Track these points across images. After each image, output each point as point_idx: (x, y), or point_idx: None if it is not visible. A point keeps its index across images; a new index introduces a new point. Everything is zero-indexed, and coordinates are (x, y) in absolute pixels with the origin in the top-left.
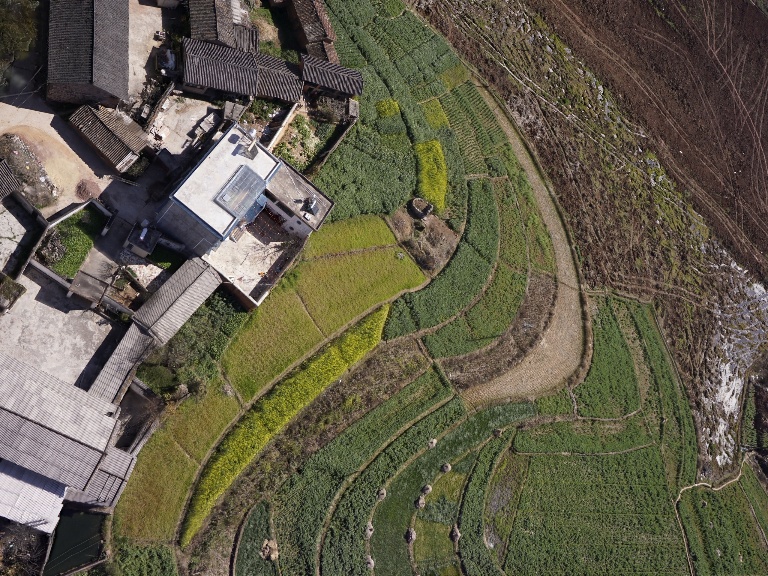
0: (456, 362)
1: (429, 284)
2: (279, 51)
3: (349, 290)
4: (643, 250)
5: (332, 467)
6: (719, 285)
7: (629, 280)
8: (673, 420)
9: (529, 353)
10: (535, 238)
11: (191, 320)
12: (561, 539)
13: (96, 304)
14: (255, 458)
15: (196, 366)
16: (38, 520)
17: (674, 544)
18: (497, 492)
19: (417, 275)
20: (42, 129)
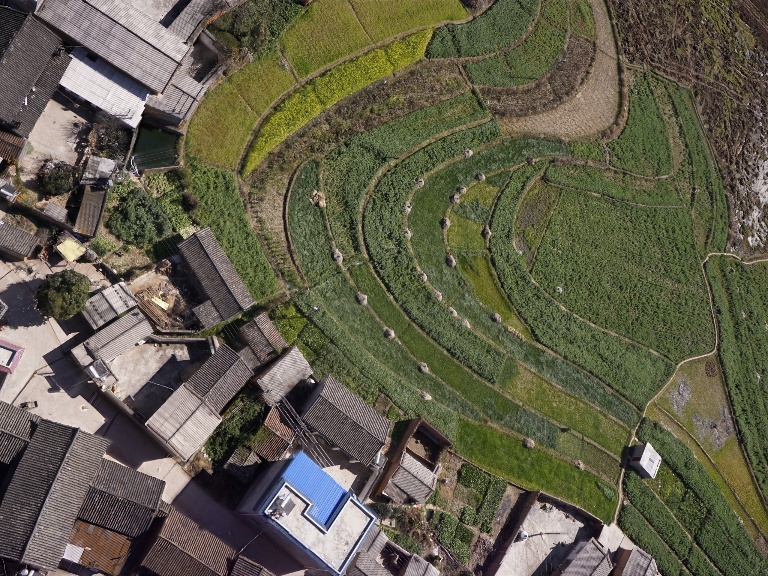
0: (494, 92)
1: (471, 20)
2: None
3: (396, 9)
4: (685, 42)
5: (376, 148)
6: (762, 90)
7: (669, 65)
8: (705, 194)
9: (565, 101)
10: (576, 6)
11: (254, 0)
12: (587, 263)
13: None
14: (308, 124)
15: None
16: (125, 115)
17: (699, 296)
18: (528, 211)
19: (460, 11)
20: None
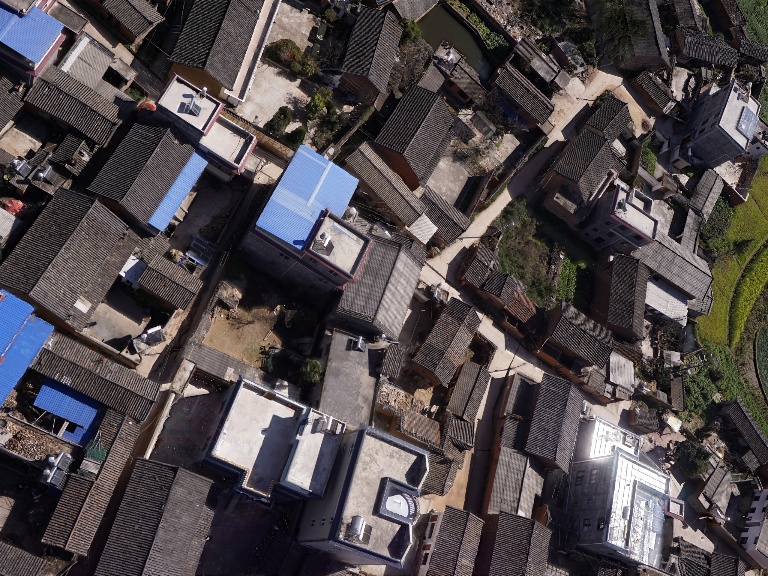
0: None
1: None
2: (712, 33)
3: None
4: None
5: None
6: None
7: None
8: None
9: None
10: None
11: None
12: None
13: (671, 195)
14: None
15: (716, 239)
16: (678, 318)
17: None
18: None
19: None
20: (619, 87)
